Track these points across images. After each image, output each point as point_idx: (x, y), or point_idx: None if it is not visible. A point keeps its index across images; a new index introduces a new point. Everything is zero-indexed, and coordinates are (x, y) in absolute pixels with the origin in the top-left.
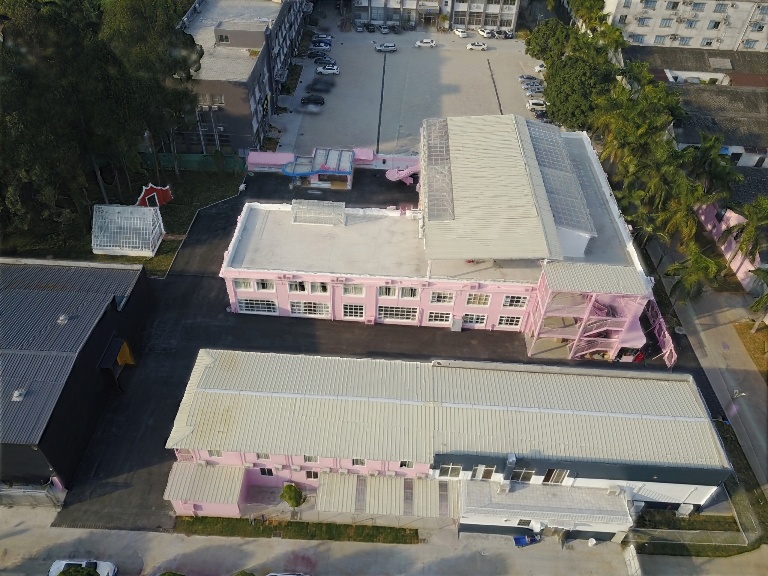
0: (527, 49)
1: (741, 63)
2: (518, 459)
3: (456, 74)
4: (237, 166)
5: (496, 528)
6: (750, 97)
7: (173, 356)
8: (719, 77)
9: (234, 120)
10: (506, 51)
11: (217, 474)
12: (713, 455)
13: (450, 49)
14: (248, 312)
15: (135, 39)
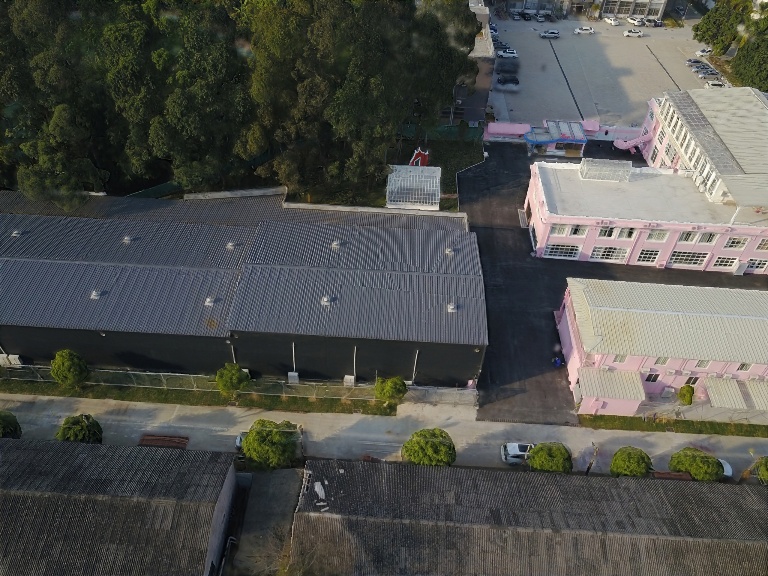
0: (696, 34)
1: None
2: None
3: (624, 58)
4: (477, 135)
5: None
6: None
7: (506, 291)
8: None
9: None
10: (660, 38)
11: (618, 377)
12: None
13: (607, 36)
14: (551, 257)
15: (454, 14)
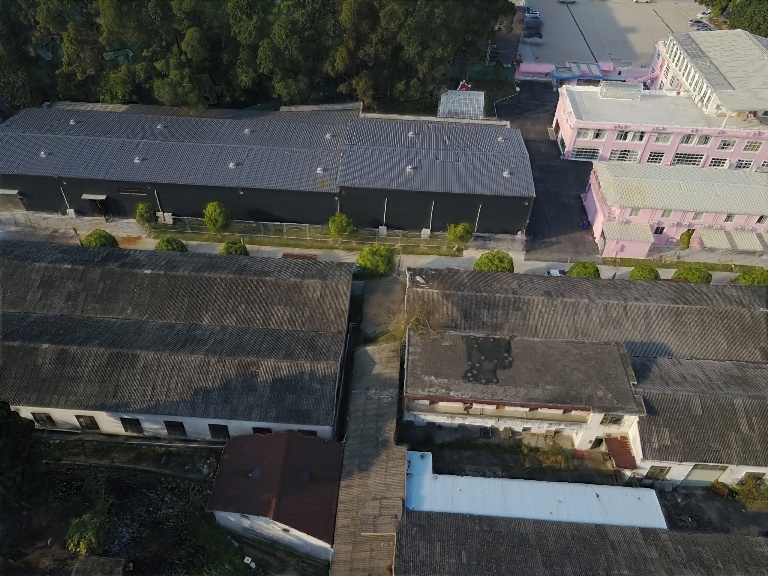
0: None
1: None
2: None
3: (634, 19)
4: (510, 74)
5: None
6: None
7: (542, 181)
8: None
9: (506, 39)
10: (666, 3)
11: (633, 228)
12: None
13: (618, 2)
14: (576, 159)
15: None
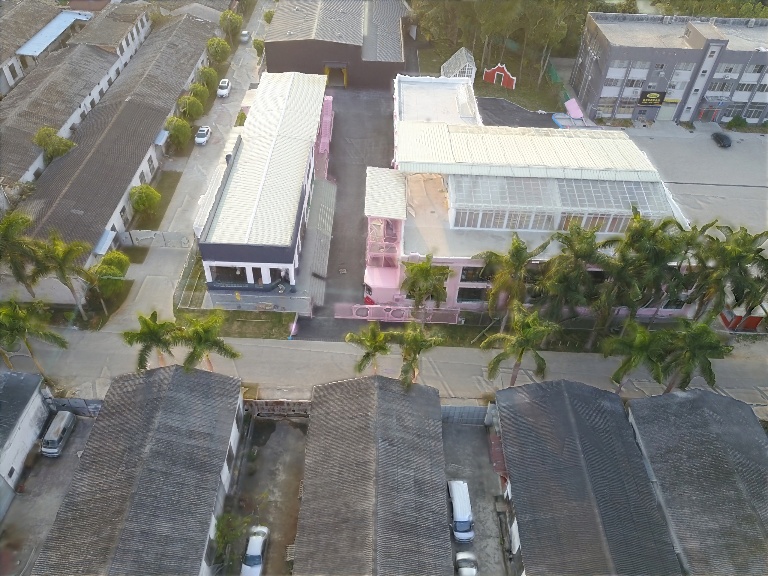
0: None
1: None
2: (230, 159)
3: None
4: (560, 102)
5: None
6: None
7: (353, 98)
8: None
9: None
10: None
11: None
12: None
13: None
14: None
15: None
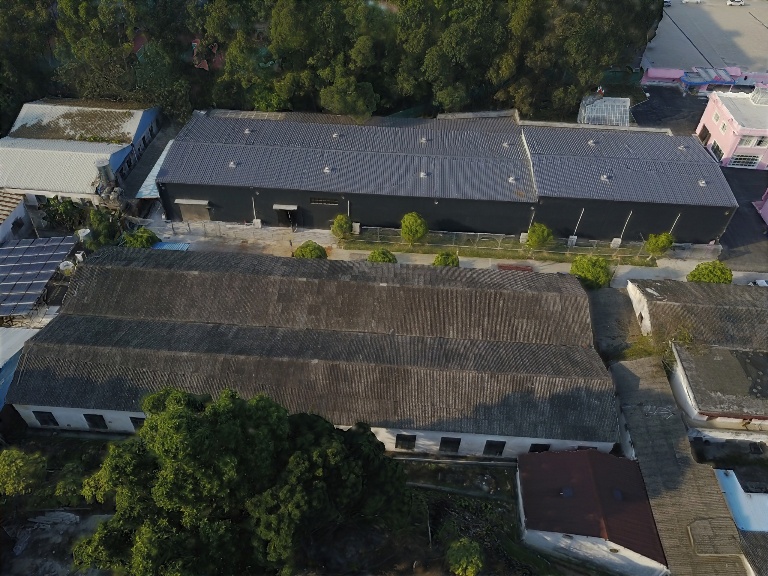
0: None
1: None
2: None
3: (734, 23)
4: (638, 79)
5: None
6: None
7: None
8: None
9: None
10: (760, 7)
11: None
12: None
13: (712, 5)
14: (733, 166)
15: None
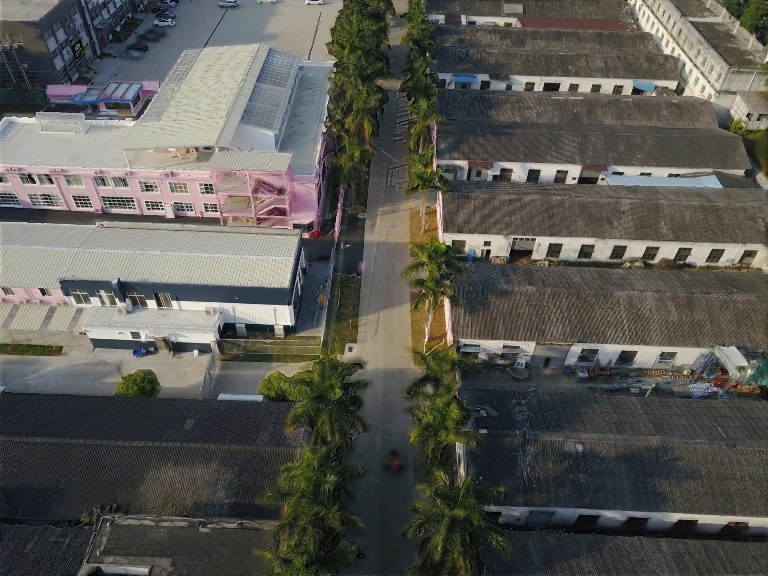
0: None
1: (533, 8)
2: (122, 283)
3: (284, 25)
4: (37, 98)
5: (120, 343)
6: (519, 35)
7: None
8: (513, 21)
9: (35, 58)
10: (341, 5)
11: None
12: (285, 281)
13: (290, 4)
14: None
15: None
